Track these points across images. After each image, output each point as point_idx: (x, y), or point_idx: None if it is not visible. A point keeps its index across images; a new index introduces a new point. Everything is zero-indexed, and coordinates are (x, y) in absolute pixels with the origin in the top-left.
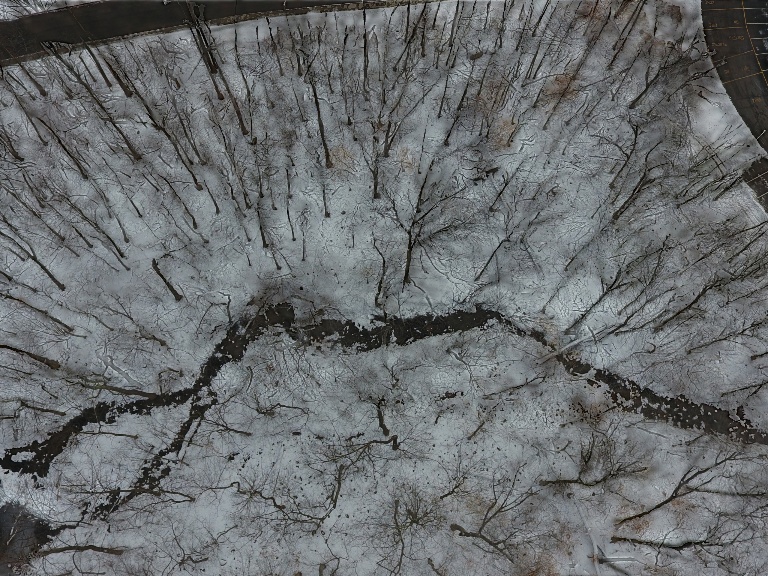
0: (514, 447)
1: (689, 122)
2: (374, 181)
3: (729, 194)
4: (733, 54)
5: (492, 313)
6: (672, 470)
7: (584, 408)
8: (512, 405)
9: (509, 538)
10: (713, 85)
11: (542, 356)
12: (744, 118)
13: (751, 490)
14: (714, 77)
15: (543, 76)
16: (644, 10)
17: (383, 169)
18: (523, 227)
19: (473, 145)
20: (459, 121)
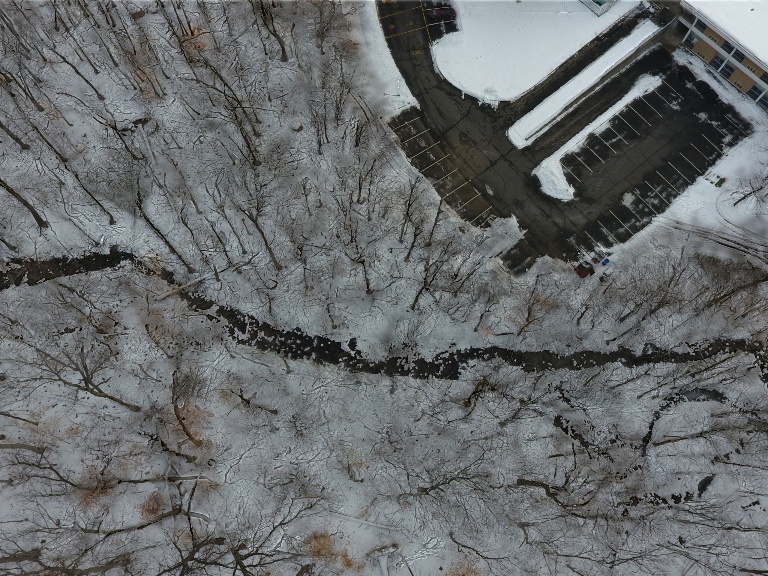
0: (118, 377)
1: (342, 74)
2: (4, 130)
3: (364, 139)
4: (401, 10)
5: (126, 255)
6: (261, 395)
7: (198, 341)
8: (126, 339)
9: (91, 459)
10: (374, 39)
11: (162, 293)
12: (401, 70)
13: (250, 397)
14: (377, 32)
15: (200, 33)
16: None
17: (33, 122)
18: None
19: (128, 99)
20: (43, 66)
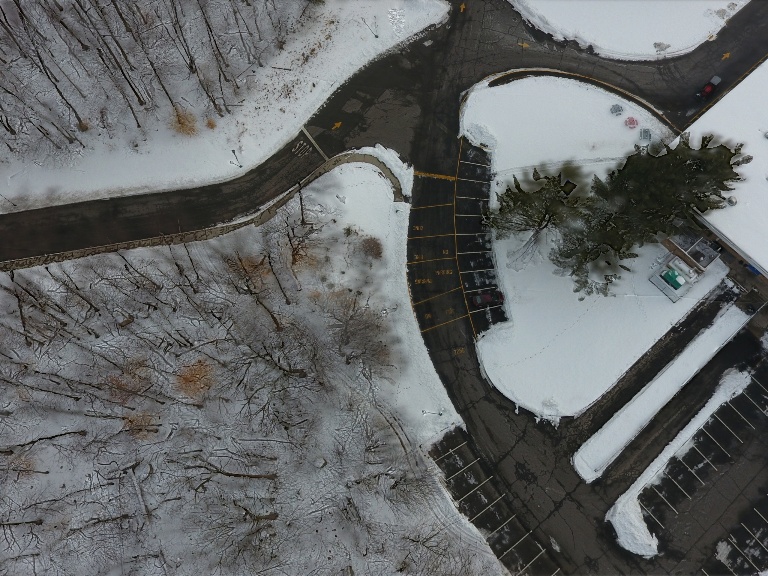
0: None
1: (371, 388)
2: None
3: (402, 487)
4: (438, 293)
5: None
6: None
7: None
8: None
9: None
10: (408, 336)
11: None
12: (441, 376)
13: None
14: (411, 325)
15: (201, 343)
16: (330, 251)
17: None
18: (160, 537)
19: (115, 432)
20: None
